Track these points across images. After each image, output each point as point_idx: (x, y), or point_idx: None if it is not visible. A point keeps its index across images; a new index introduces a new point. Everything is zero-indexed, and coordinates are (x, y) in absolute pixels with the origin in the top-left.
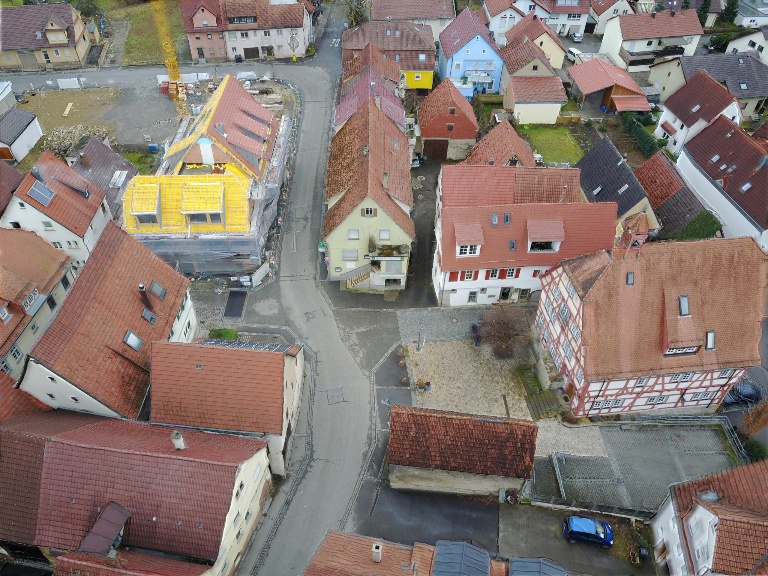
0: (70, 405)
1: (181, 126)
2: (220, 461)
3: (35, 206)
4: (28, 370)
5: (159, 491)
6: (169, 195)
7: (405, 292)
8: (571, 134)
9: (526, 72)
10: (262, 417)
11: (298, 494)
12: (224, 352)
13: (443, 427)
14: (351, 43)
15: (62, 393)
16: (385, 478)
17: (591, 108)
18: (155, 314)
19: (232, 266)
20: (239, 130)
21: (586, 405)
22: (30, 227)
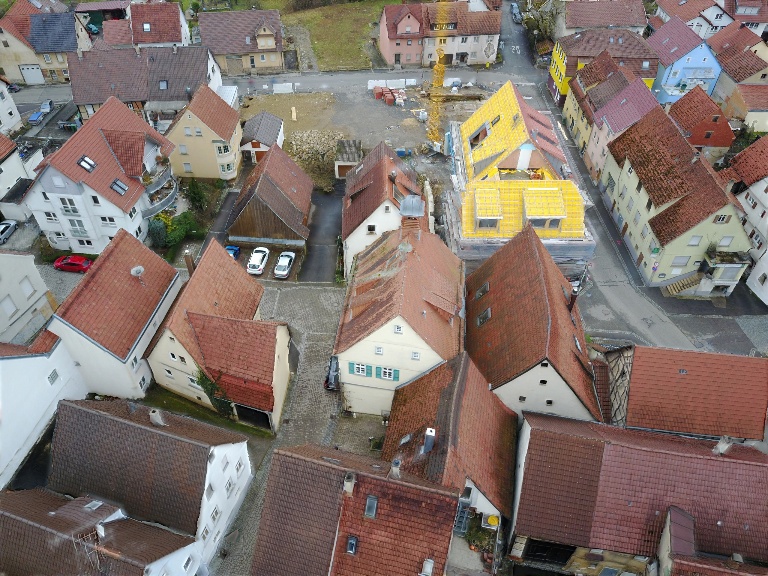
0: (537, 408)
1: (453, 131)
2: None
3: None
4: (527, 373)
5: (725, 495)
6: (508, 200)
7: (731, 299)
8: None
9: (753, 80)
10: (744, 422)
11: None
12: (711, 357)
13: None
14: (576, 50)
15: (540, 396)
16: None
17: None
18: None
19: None
20: None
21: None
22: (385, 230)
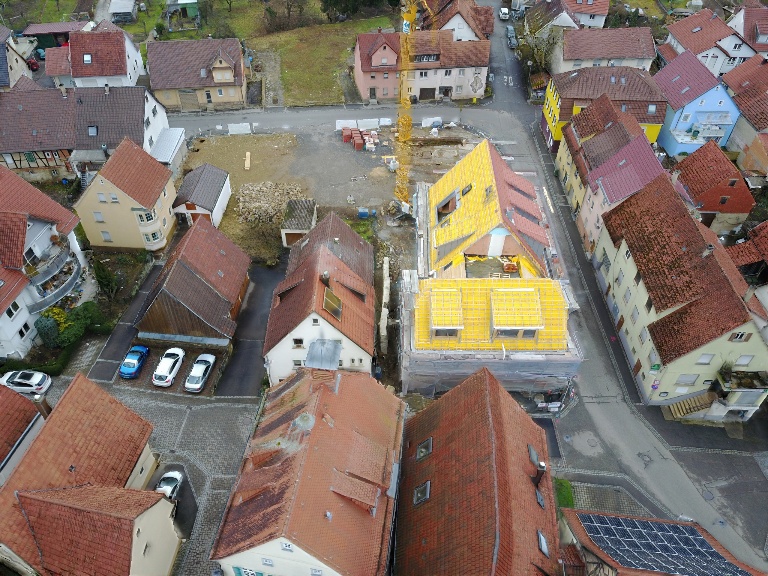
0: None
1: (419, 196)
2: None
3: (332, 323)
4: None
5: None
6: (472, 303)
7: (749, 425)
8: None
9: None
10: None
11: None
12: None
13: None
14: (571, 91)
15: None
16: None
17: None
18: (540, 492)
19: (529, 385)
20: (515, 211)
21: None
22: None
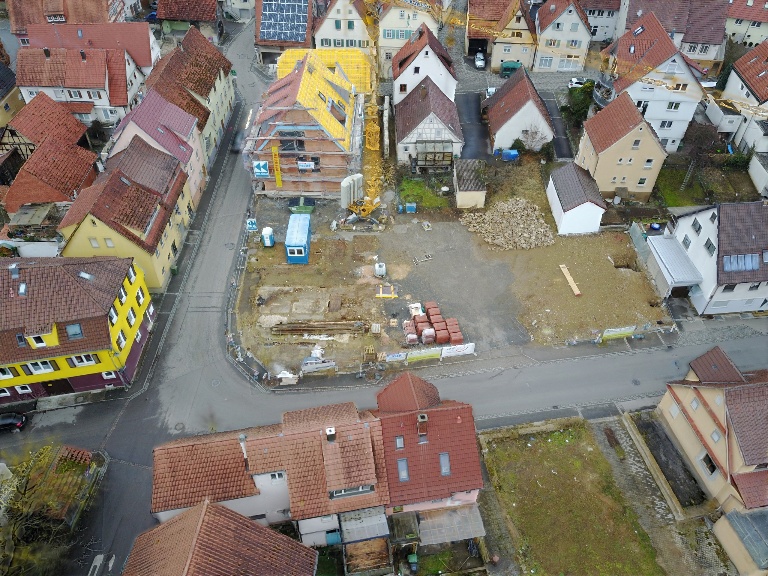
0: None
1: None
2: None
3: None
4: None
5: None
6: None
7: None
8: None
9: None
10: None
11: None
12: None
13: None
14: None
15: None
16: None
17: None
18: None
19: None
20: None
21: None
22: None
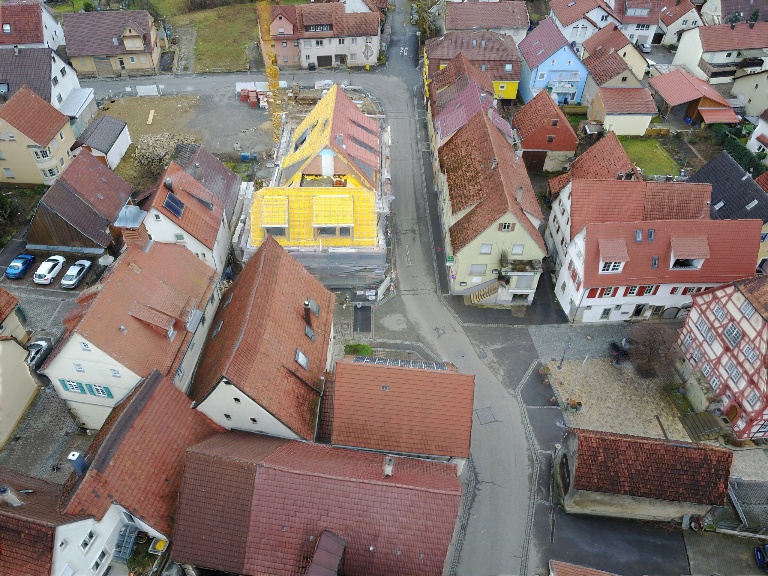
0: (246, 426)
1: (283, 136)
2: (441, 489)
3: (171, 218)
4: (215, 391)
5: (377, 520)
6: (297, 207)
7: (532, 308)
8: (662, 146)
9: (615, 83)
10: (449, 440)
11: (472, 519)
12: (413, 373)
13: (633, 452)
14: (437, 53)
15: (242, 414)
16: (557, 502)
17: (675, 120)
18: (314, 331)
19: (354, 280)
20: (353, 141)
21: (753, 428)
22: (162, 239)
